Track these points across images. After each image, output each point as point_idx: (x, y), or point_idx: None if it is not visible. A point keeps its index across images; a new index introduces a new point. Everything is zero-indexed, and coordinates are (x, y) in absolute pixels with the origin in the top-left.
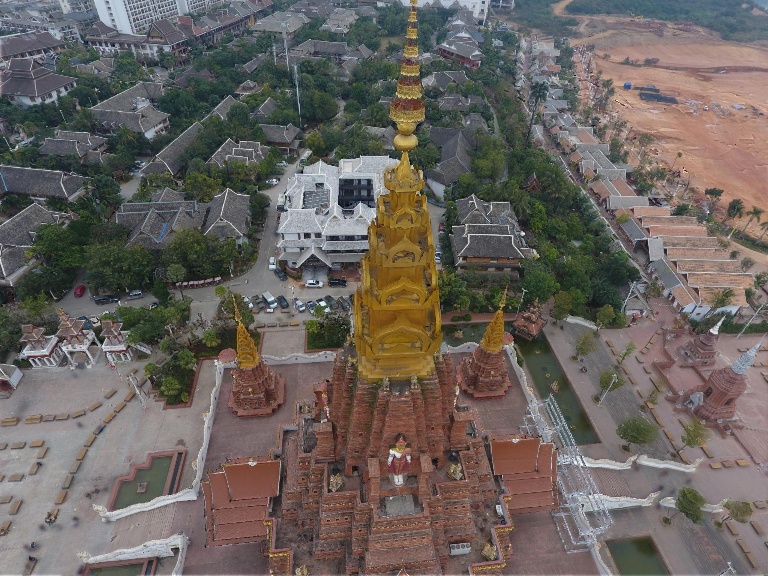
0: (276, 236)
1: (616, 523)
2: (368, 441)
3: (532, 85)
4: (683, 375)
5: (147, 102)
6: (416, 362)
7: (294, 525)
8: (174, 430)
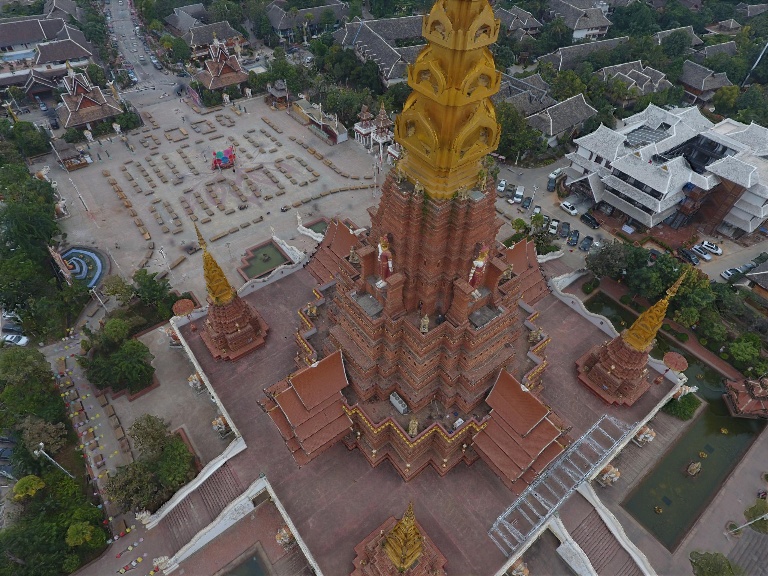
0: None
1: None
2: None
3: None
4: None
5: (606, 8)
6: (434, 177)
7: None
8: None
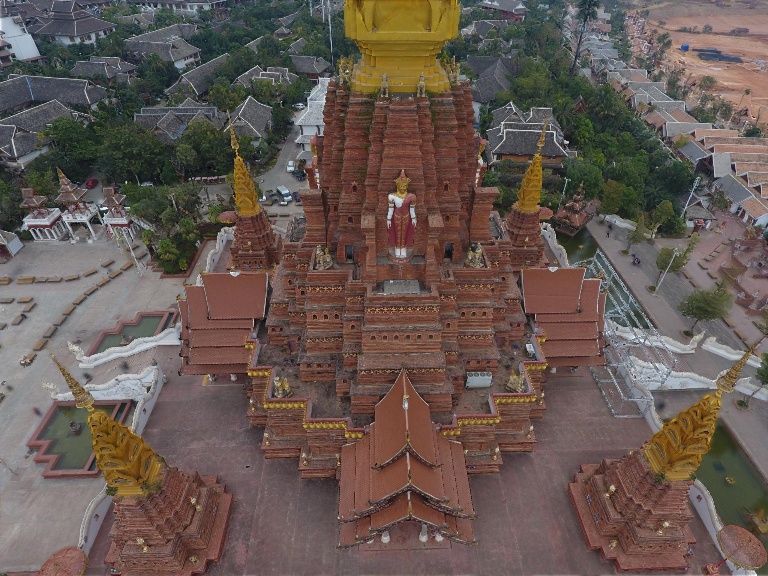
0: (297, 147)
1: (677, 403)
2: (364, 200)
3: (581, 2)
4: (756, 285)
5: None
6: (424, 69)
7: (280, 350)
8: (169, 295)
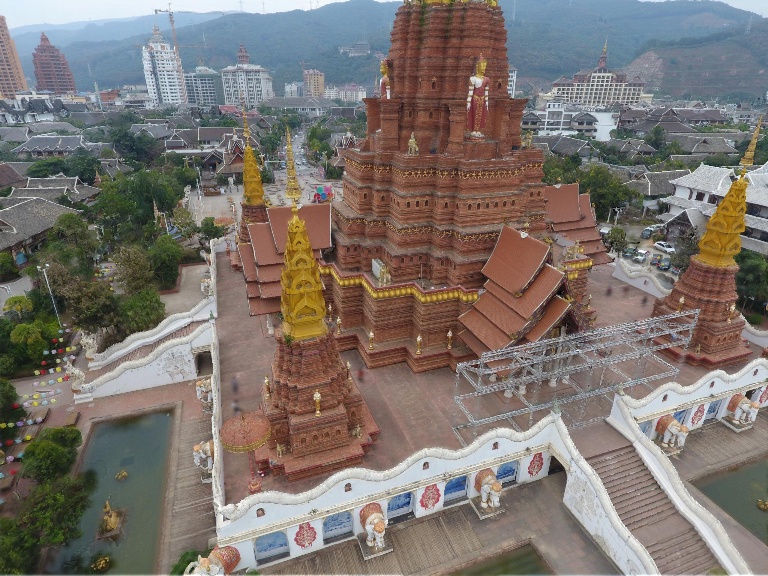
0: None
1: (585, 567)
2: None
3: None
4: None
5: (731, 144)
6: None
7: None
8: None
